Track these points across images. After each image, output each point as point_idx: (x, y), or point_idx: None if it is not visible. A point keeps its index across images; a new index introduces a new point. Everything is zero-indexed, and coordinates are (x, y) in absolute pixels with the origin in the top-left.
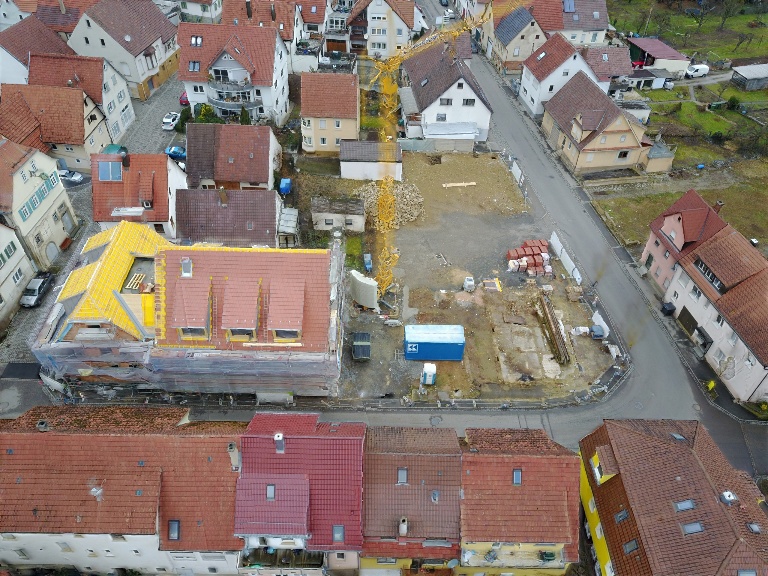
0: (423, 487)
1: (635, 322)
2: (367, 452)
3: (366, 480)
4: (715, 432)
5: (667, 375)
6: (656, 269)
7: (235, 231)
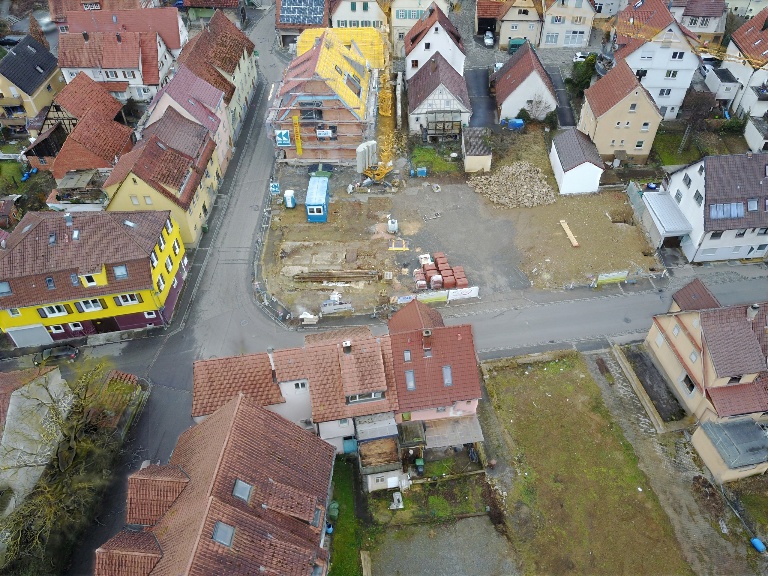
0: None
1: None
2: (170, 108)
3: None
4: None
5: None
6: None
7: (417, 92)
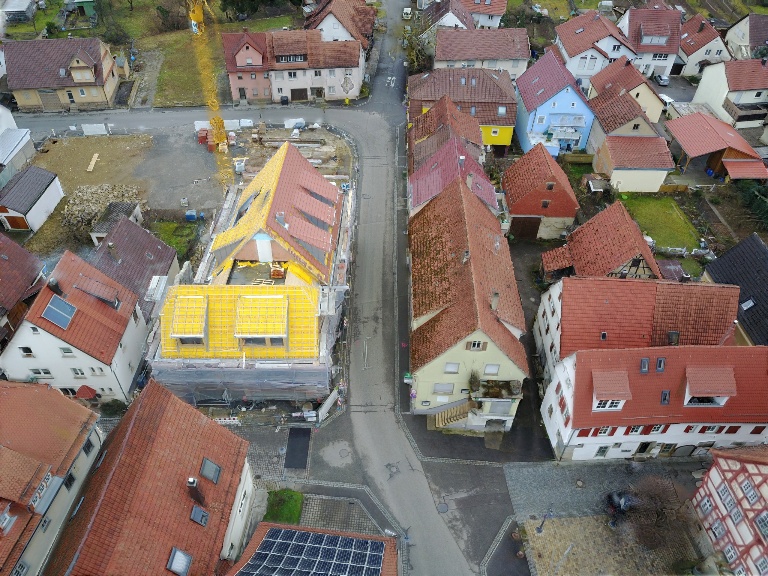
0: None
1: (291, 115)
2: None
3: None
4: (376, 110)
5: (335, 114)
6: (252, 92)
7: (149, 270)
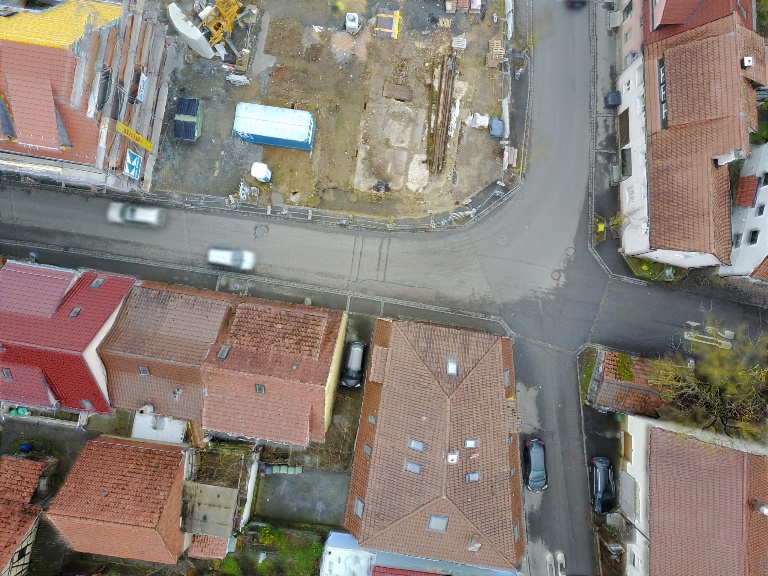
0: (167, 380)
1: (559, 114)
2: (103, 348)
3: (109, 366)
4: (573, 286)
5: (559, 202)
6: (628, 29)
7: None
